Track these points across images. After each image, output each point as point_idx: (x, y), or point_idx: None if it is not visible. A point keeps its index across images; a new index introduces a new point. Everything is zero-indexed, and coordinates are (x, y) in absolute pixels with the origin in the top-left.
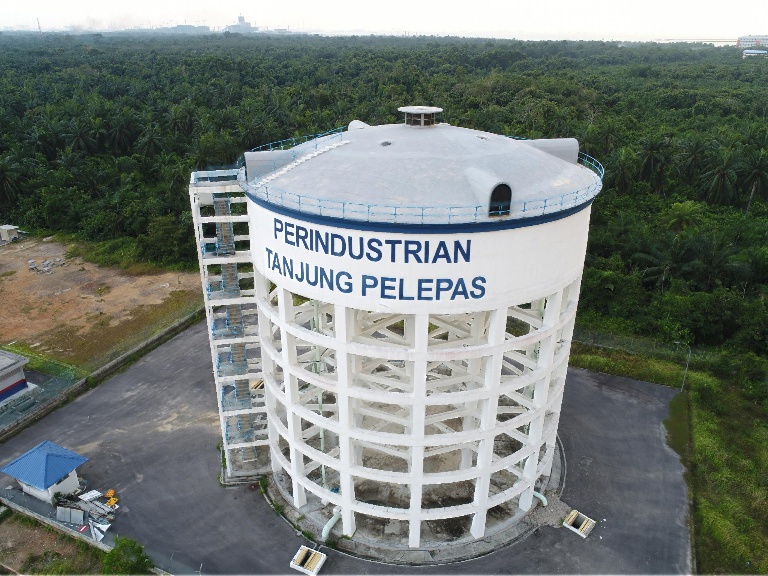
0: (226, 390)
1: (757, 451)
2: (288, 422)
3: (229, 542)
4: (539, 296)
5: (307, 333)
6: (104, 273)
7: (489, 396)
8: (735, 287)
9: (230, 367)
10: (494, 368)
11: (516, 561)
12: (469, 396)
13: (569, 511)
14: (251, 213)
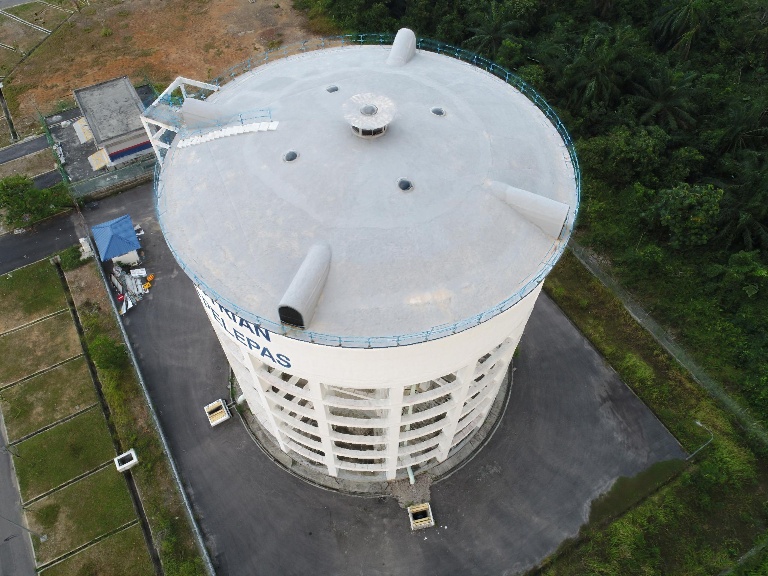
0: None
1: (680, 569)
2: None
3: (186, 364)
4: (359, 387)
5: None
6: (291, 18)
7: (317, 419)
8: None
9: None
10: (316, 408)
11: (344, 510)
12: (297, 412)
13: (426, 501)
14: None
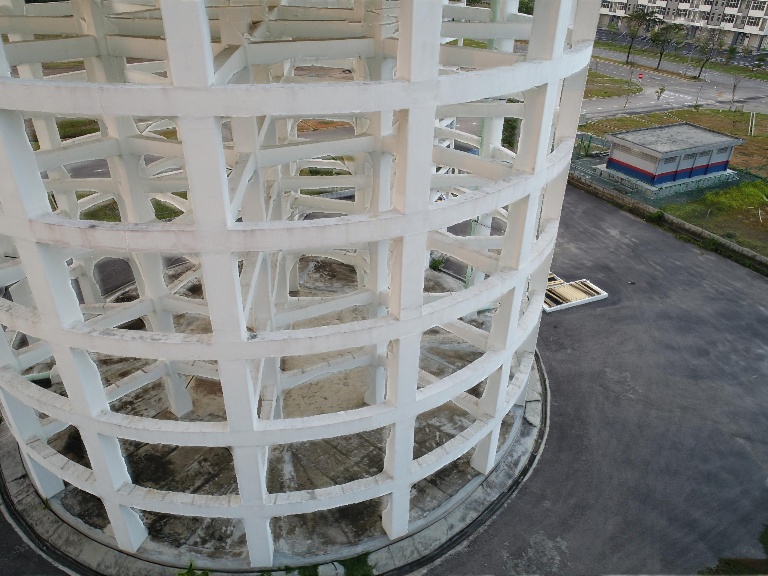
0: (569, 277)
1: None
2: None
3: None
4: None
5: None
6: None
7: None
8: None
9: None
10: None
11: None
12: None
13: None
14: None
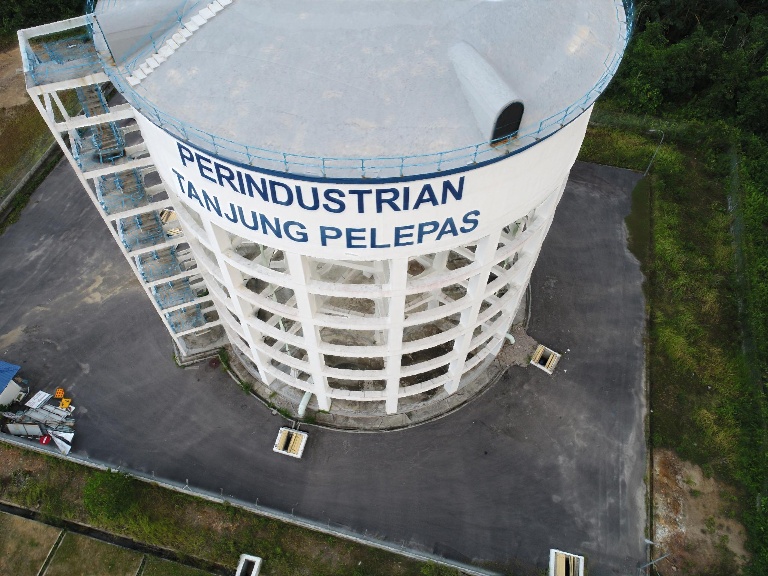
0: None
1: (712, 244)
2: (243, 328)
3: (205, 433)
4: (538, 203)
5: (253, 270)
6: None
7: (472, 304)
8: (717, 32)
9: (156, 265)
10: (480, 282)
11: (489, 410)
12: (451, 311)
13: (535, 346)
14: (135, 111)
